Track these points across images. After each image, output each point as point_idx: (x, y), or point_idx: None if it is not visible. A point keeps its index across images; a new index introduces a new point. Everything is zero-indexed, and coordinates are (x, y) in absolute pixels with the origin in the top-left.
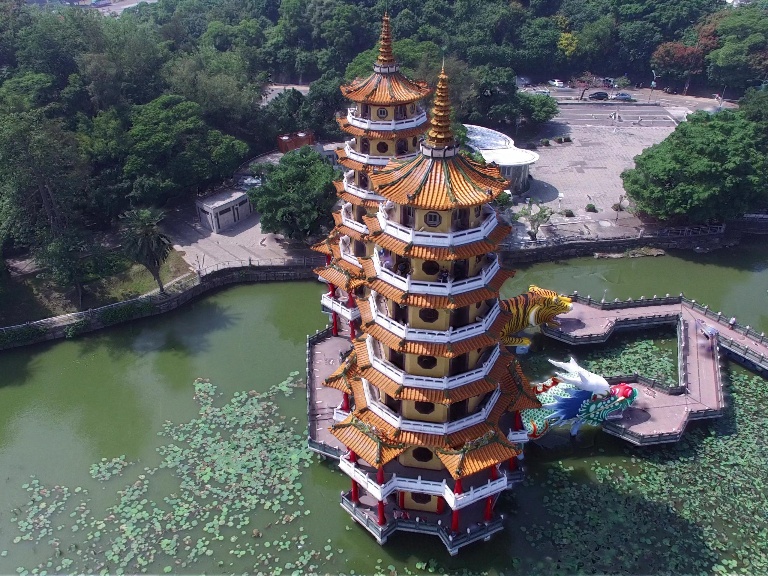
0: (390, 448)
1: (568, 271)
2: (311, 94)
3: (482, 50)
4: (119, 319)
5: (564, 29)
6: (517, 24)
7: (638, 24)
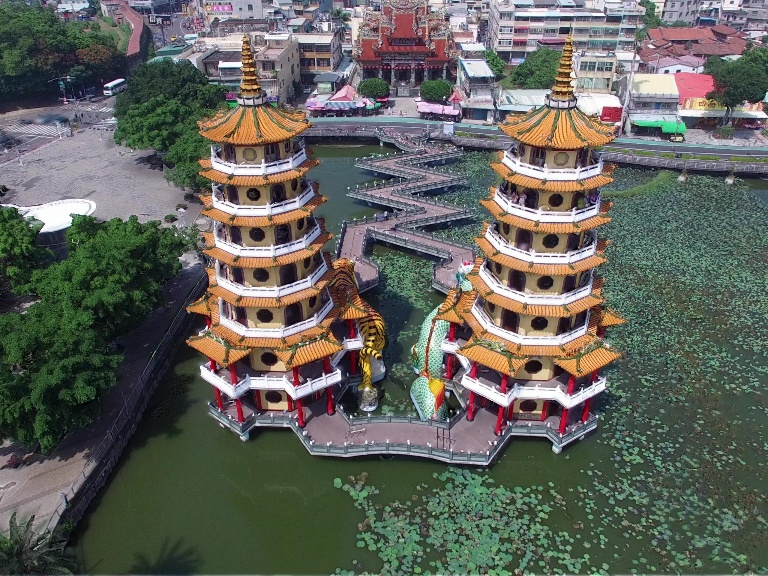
0: None
1: None
2: None
3: None
4: None
5: None
6: None
7: None
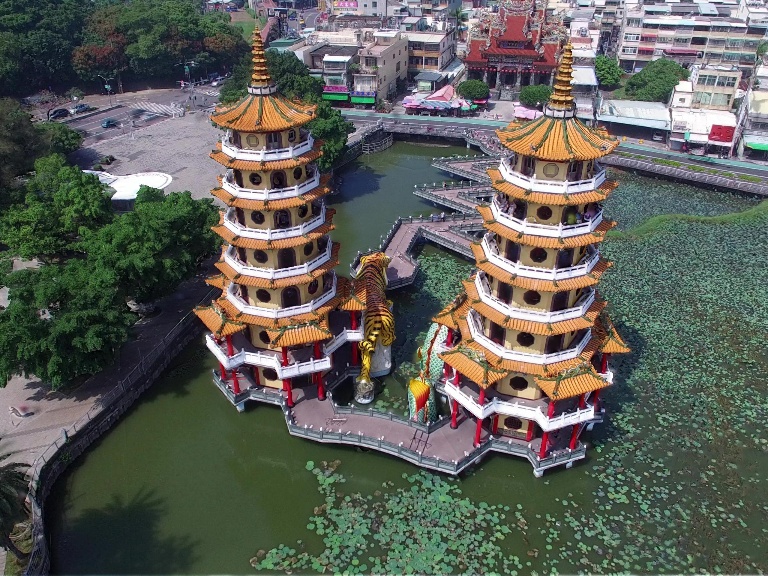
0: (591, 370)
1: None
2: None
3: None
4: None
5: None
6: None
7: (40, 33)
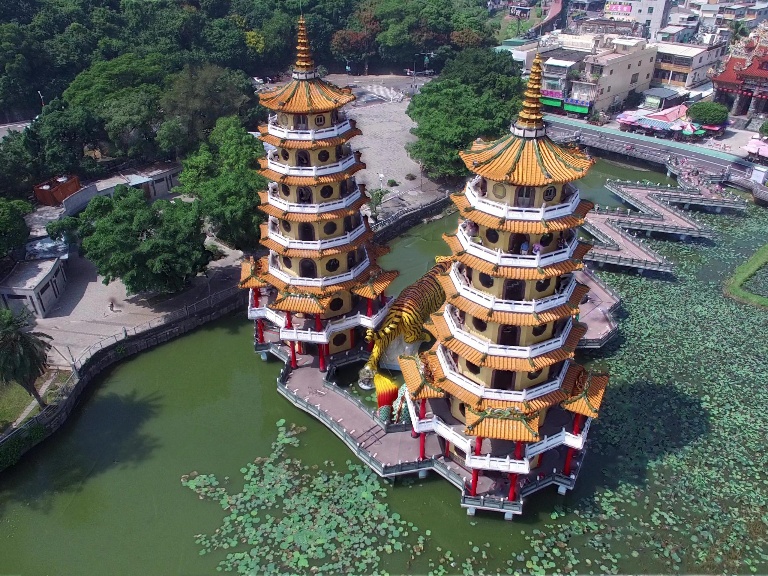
0: (531, 420)
1: (405, 242)
2: (53, 130)
3: (177, 58)
4: (10, 462)
5: (244, 28)
6: (198, 27)
7: (310, 16)
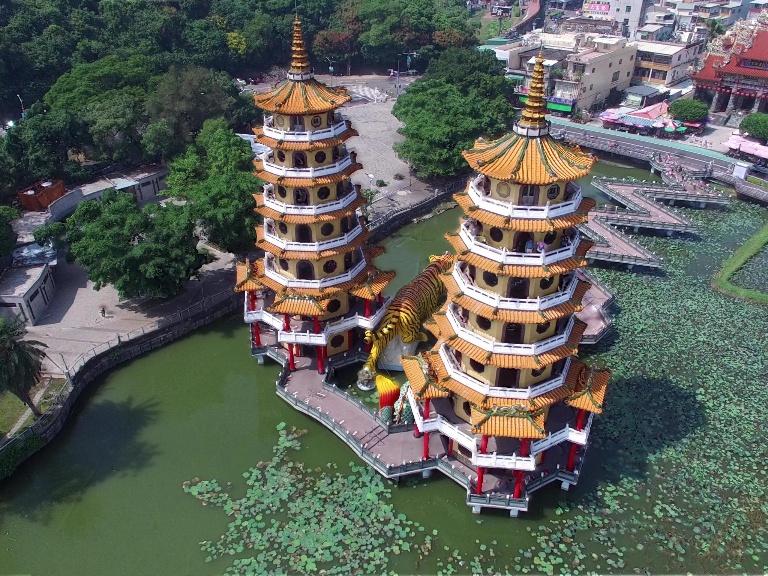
0: (536, 417)
1: (395, 242)
2: (36, 134)
3: (158, 59)
4: (6, 473)
5: (225, 29)
6: (179, 29)
7: (292, 17)
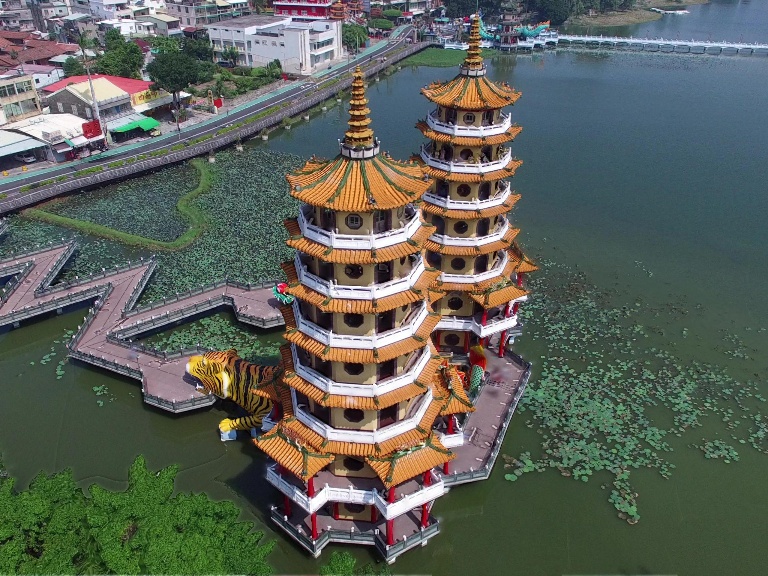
0: None
1: None
2: None
3: None
4: None
5: None
6: None
7: None
